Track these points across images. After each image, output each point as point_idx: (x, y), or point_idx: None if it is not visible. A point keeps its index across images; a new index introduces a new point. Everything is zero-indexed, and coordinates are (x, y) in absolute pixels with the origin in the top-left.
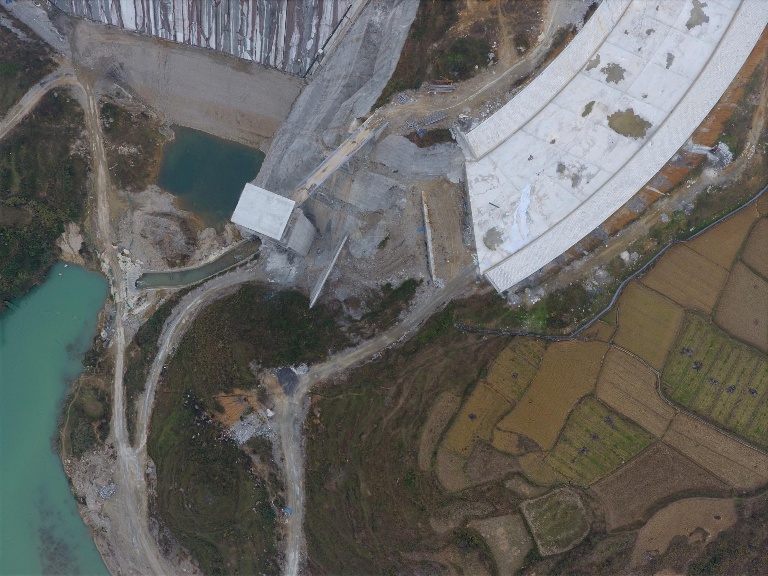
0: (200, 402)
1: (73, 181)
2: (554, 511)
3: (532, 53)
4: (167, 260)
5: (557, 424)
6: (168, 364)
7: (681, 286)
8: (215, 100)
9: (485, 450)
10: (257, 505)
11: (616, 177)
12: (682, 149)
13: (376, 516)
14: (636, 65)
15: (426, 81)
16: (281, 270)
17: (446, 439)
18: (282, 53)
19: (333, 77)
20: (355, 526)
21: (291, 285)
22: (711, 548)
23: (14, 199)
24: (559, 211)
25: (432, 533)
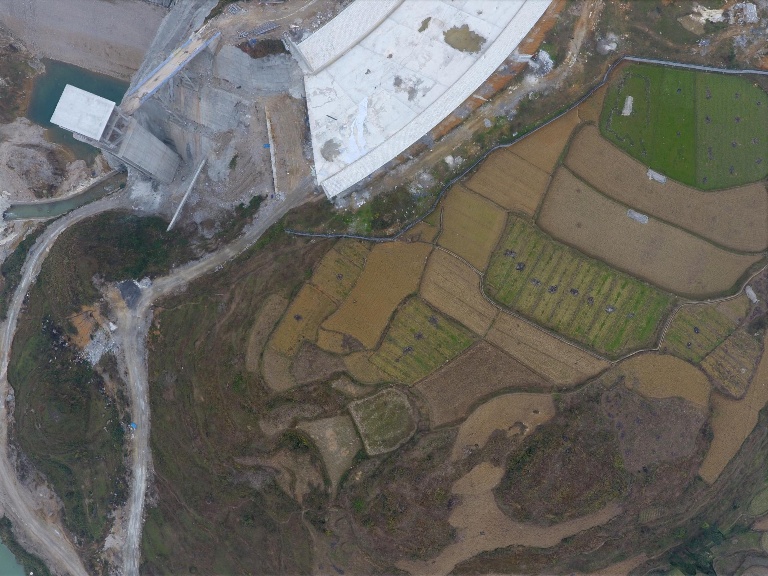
0: (58, 326)
1: None
2: (381, 411)
3: None
4: (33, 190)
5: (381, 323)
6: None
7: (504, 189)
8: (82, 31)
9: (311, 350)
10: (108, 424)
11: (450, 89)
12: (509, 59)
13: (209, 422)
14: None
15: None
16: (146, 198)
17: (272, 340)
18: None
19: (188, 2)
20: (192, 434)
21: (155, 212)
22: (527, 440)
23: None
24: (395, 123)
25: (261, 435)
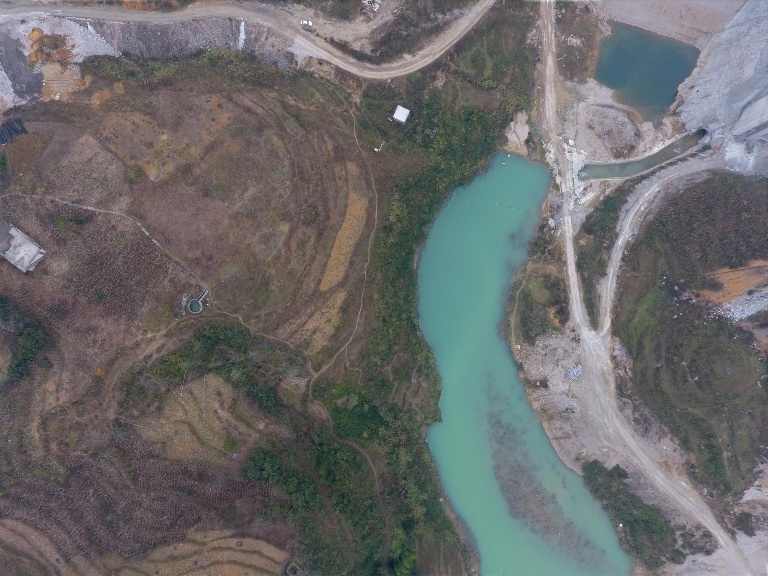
0: (680, 283)
1: (529, 69)
2: None
3: None
4: (616, 150)
5: None
6: (628, 250)
7: None
8: None
9: None
10: (762, 379)
11: None
12: None
13: None
14: None
15: None
16: (739, 159)
17: None
18: None
19: None
20: None
21: (752, 173)
22: None
23: (490, 82)
24: None
25: None
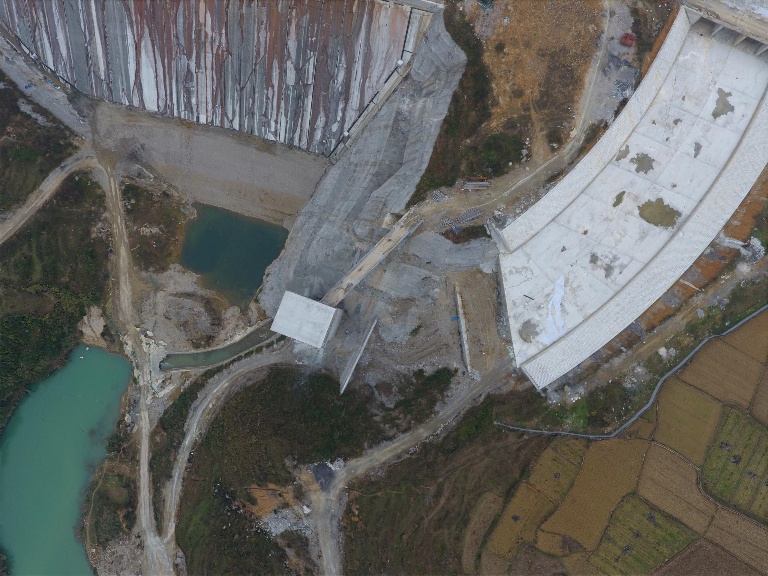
0: (230, 491)
1: (95, 264)
2: None
3: (565, 149)
4: (192, 342)
5: (601, 524)
6: (195, 450)
7: (718, 381)
8: (238, 179)
9: (529, 552)
10: None
11: (649, 268)
12: (714, 242)
13: None
14: (664, 155)
15: (460, 178)
16: (309, 351)
17: (490, 542)
18: (307, 134)
19: (360, 162)
20: None
21: (319, 367)
22: None
23: (36, 287)
24: (593, 302)
25: None
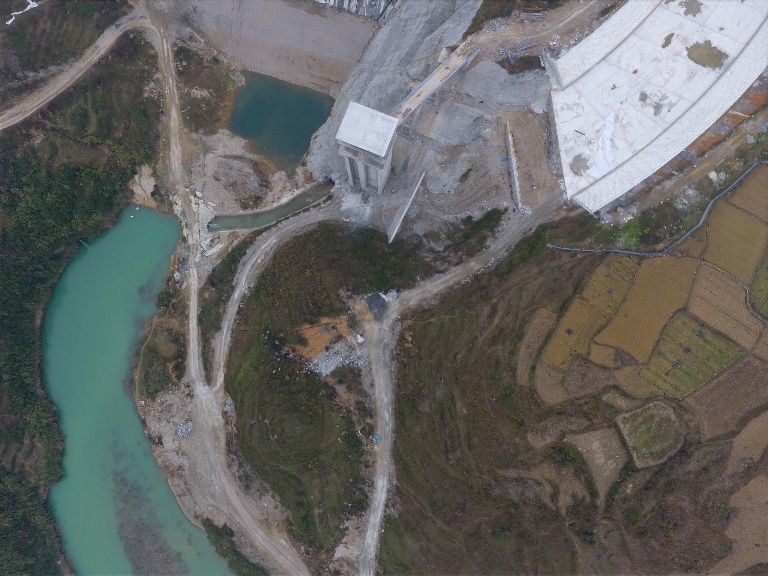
0: (280, 337)
1: (147, 123)
2: (649, 424)
3: None
4: (240, 201)
5: (652, 337)
6: (244, 303)
7: (766, 205)
8: (287, 44)
9: (582, 364)
10: (342, 435)
11: (697, 105)
12: (762, 76)
13: (472, 434)
14: None
15: (516, 9)
16: (356, 209)
17: (544, 353)
18: None
19: (411, 16)
20: (449, 446)
21: (366, 224)
22: None
23: (91, 138)
24: (642, 138)
25: (530, 448)
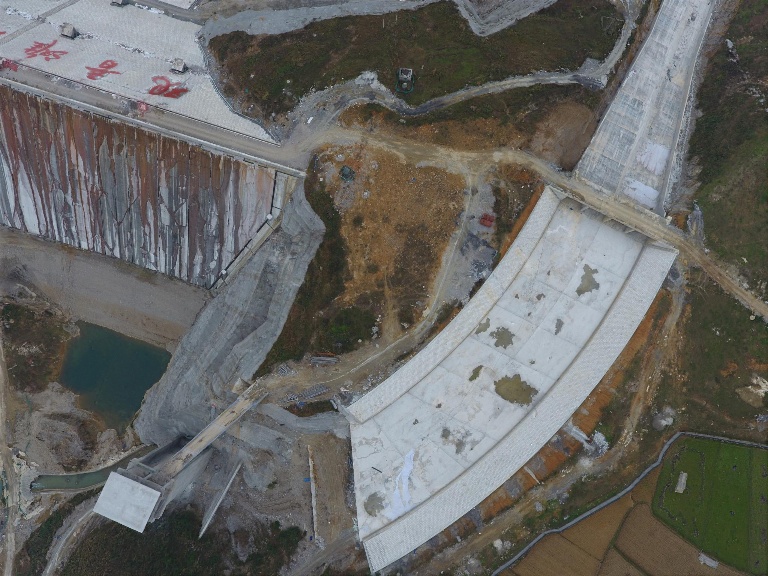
0: None
1: None
2: None
3: (416, 328)
4: (63, 466)
5: None
6: None
7: (553, 575)
8: (120, 304)
9: None
10: None
11: (499, 447)
12: (562, 430)
13: None
14: (525, 330)
15: (309, 352)
16: None
17: None
18: (186, 268)
19: (232, 306)
20: None
21: (186, 502)
22: None
23: None
24: (442, 478)
25: None
